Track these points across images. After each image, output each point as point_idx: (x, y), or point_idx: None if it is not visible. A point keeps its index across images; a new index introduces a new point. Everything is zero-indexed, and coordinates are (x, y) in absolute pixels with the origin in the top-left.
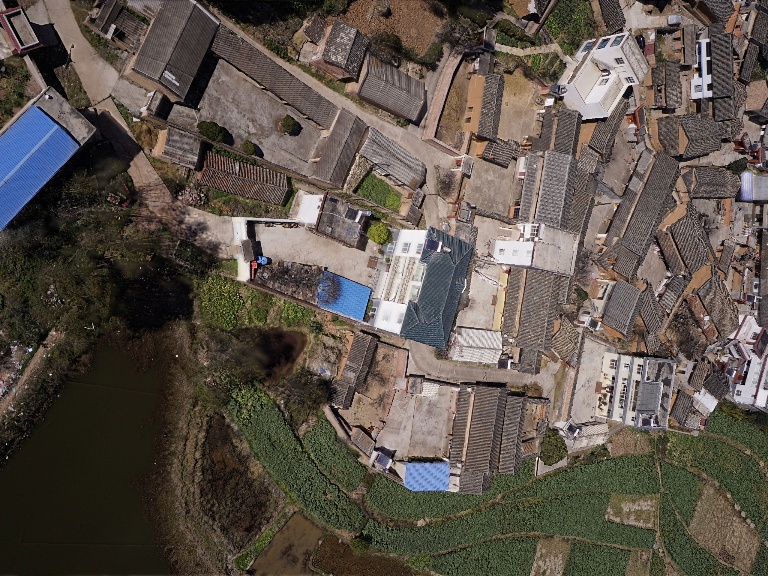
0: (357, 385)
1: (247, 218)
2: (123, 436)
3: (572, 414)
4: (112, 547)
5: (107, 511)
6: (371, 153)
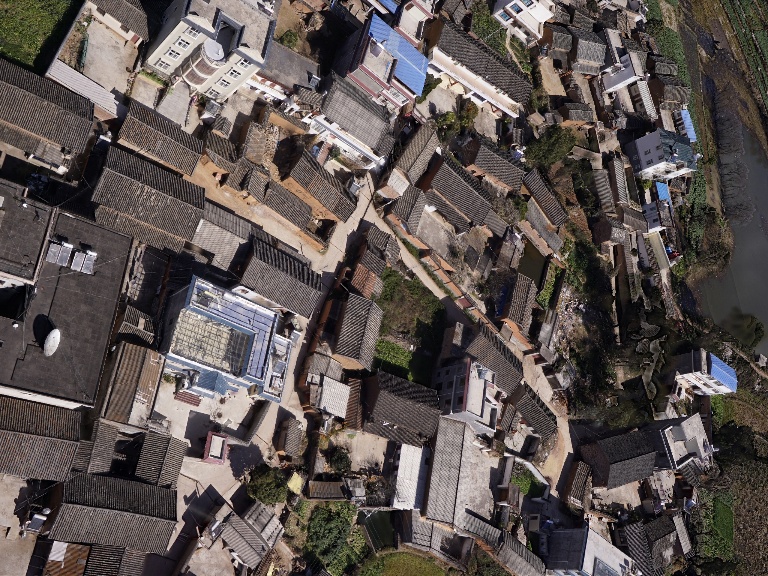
0: (683, 181)
1: (670, 264)
2: (716, 294)
3: (625, 4)
4: (736, 286)
5: (731, 292)
6: (628, 199)
